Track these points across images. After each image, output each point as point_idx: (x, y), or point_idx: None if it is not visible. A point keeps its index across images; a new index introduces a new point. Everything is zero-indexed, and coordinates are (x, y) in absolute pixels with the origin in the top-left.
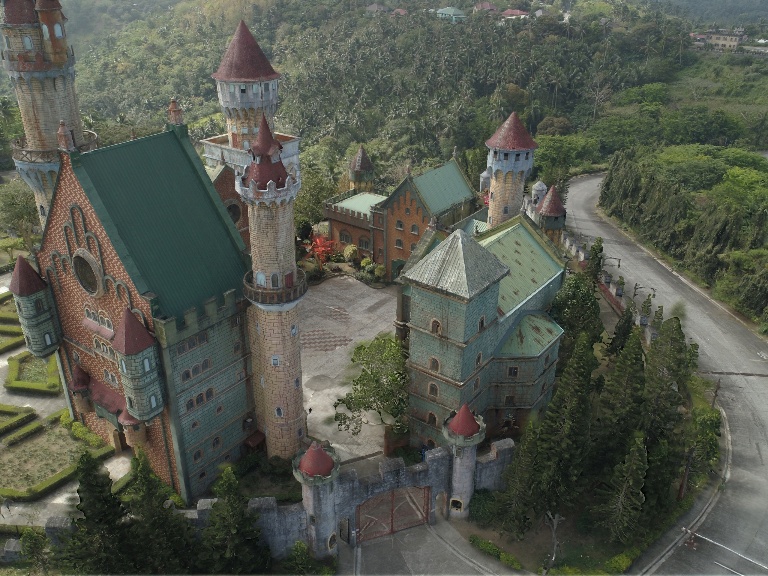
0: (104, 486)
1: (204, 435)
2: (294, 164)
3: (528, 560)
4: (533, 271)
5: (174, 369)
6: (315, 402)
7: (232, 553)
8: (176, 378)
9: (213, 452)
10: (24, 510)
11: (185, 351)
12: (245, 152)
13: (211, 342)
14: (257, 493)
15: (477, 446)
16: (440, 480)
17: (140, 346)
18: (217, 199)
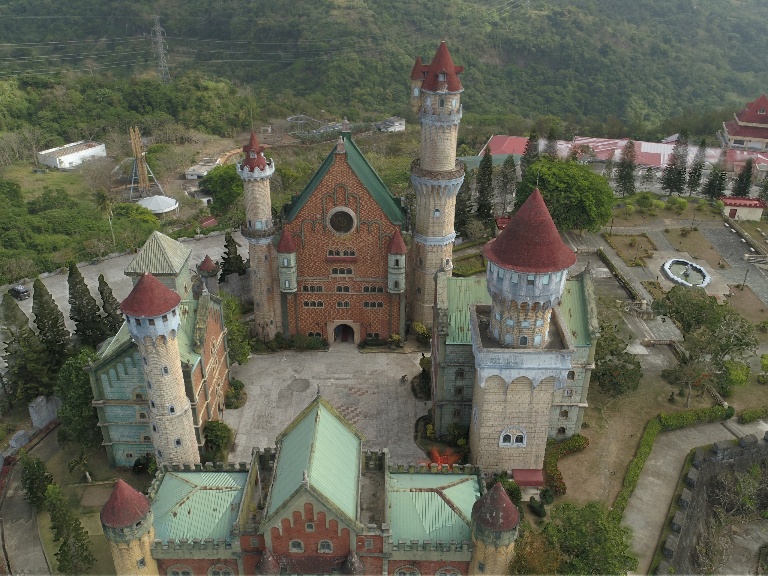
0: None
1: None
2: None
3: None
4: None
5: None
6: (289, 372)
7: None
8: None
9: None
10: None
11: None
12: None
13: None
14: None
15: None
16: None
17: None
18: None
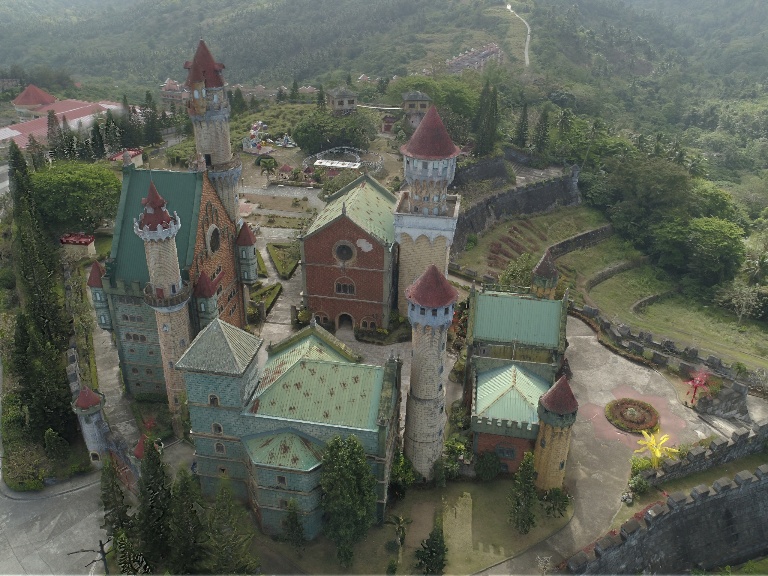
0: (23, 334)
1: (140, 361)
2: (448, 238)
3: (117, 567)
4: (338, 408)
5: (117, 309)
6: None
7: (37, 408)
8: (118, 315)
9: (147, 376)
10: (110, 346)
11: (125, 303)
12: (393, 211)
13: (144, 308)
14: (146, 416)
15: (237, 503)
16: (138, 476)
17: (93, 284)
18: (194, 226)
